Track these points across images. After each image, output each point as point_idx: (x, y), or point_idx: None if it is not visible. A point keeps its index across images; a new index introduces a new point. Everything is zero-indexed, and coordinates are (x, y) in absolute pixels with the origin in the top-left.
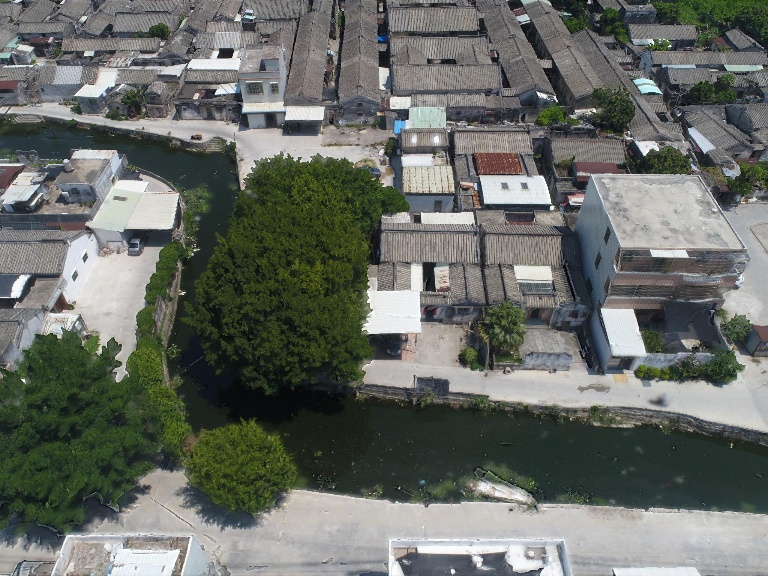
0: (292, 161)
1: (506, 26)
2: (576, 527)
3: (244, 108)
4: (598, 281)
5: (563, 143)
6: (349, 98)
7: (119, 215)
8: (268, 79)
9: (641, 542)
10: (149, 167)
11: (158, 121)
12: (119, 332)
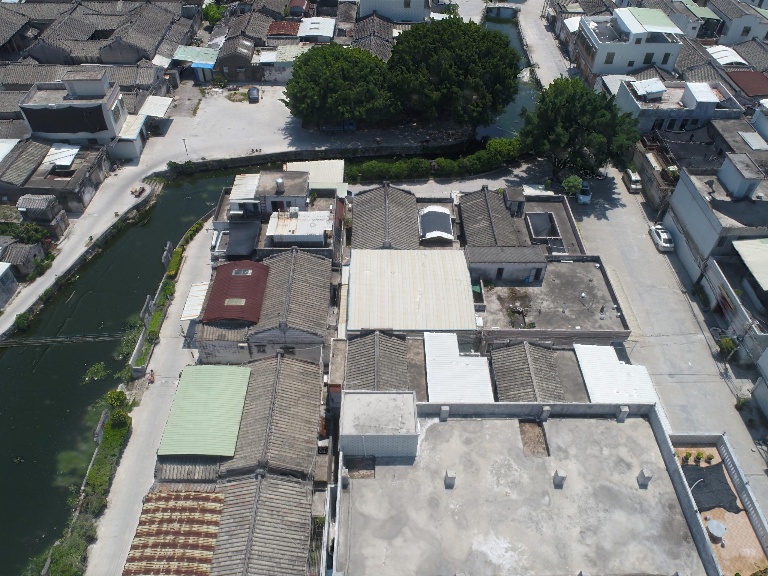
0: (311, 65)
1: (40, 4)
2: (540, 57)
3: (128, 137)
4: (415, 11)
5: (268, 5)
6: (153, 75)
7: (324, 187)
8: (117, 95)
9: (542, 46)
10: (176, 233)
11: (74, 230)
12: (448, 192)
